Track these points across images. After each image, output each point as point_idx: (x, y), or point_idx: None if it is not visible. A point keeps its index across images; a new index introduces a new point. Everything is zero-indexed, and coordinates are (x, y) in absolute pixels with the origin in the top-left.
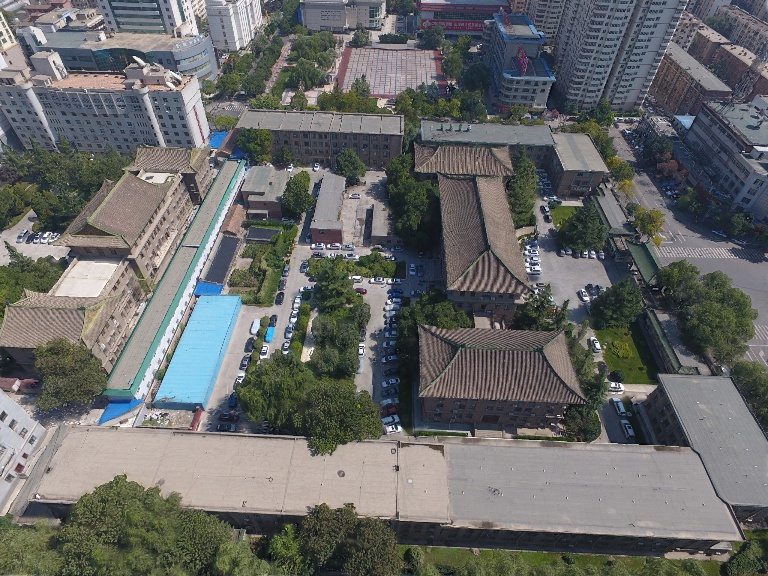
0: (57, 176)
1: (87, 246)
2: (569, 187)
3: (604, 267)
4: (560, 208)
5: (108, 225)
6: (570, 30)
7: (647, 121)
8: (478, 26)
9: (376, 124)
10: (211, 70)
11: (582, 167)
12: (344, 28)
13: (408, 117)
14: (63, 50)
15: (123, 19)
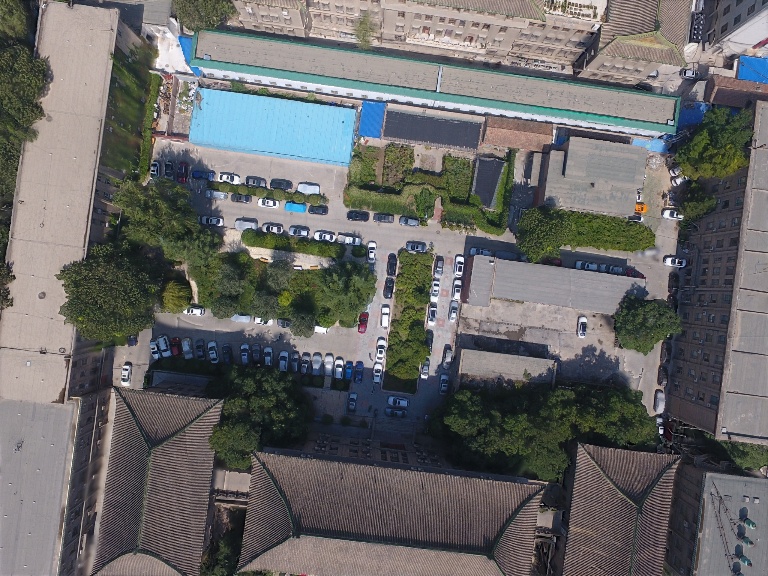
0: None
1: None
2: None
3: None
4: None
5: None
6: None
7: None
8: None
9: (765, 386)
10: None
11: None
12: None
13: None
14: None
15: None
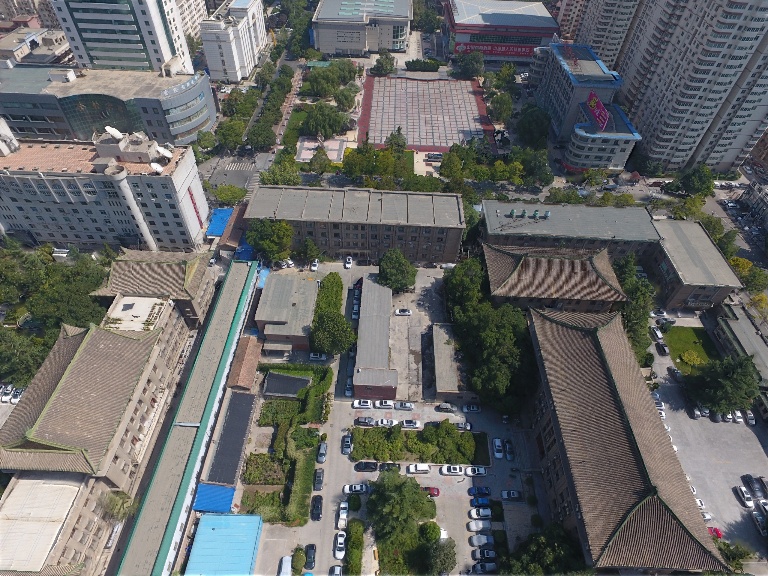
0: (2, 295)
1: (29, 469)
2: (684, 301)
3: (758, 439)
4: (674, 330)
5: (61, 433)
6: (653, 71)
7: (758, 194)
8: (521, 51)
9: (427, 209)
10: (208, 116)
11: (706, 279)
12: (363, 51)
13: (461, 190)
14: (20, 96)
15: (97, 53)
